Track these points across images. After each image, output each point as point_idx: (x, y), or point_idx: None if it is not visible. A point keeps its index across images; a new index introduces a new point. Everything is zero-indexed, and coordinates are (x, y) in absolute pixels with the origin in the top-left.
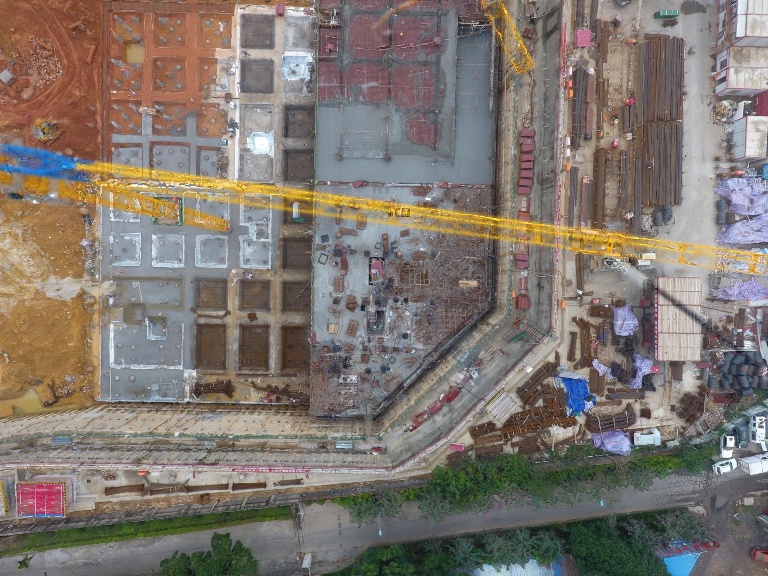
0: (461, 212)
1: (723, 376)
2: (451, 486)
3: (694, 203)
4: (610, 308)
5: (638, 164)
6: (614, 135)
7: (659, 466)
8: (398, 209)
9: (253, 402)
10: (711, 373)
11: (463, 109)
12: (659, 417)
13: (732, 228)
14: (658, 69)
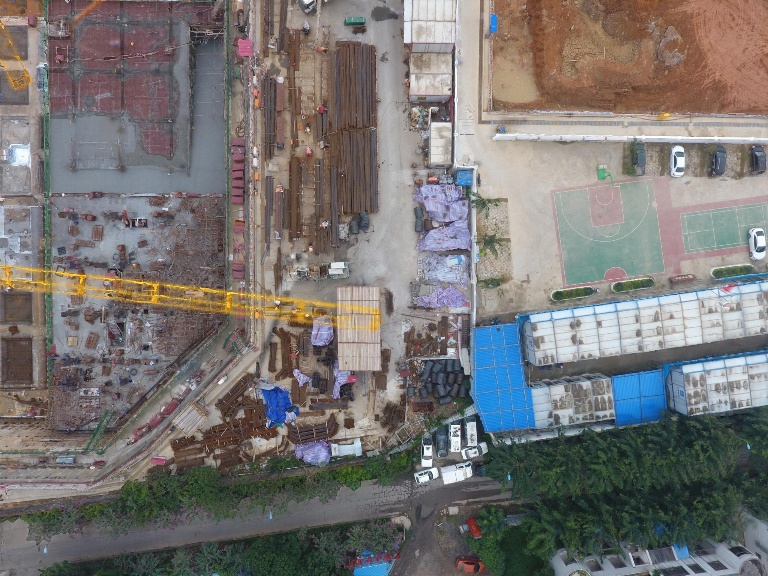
0: (198, 222)
1: (424, 384)
2: (128, 501)
3: (393, 210)
4: (310, 318)
5: (333, 172)
6: (309, 143)
7: (348, 477)
8: (135, 220)
9: (16, 416)
10: (411, 382)
11: (200, 118)
12: (363, 427)
13: (427, 235)
14: (347, 76)
